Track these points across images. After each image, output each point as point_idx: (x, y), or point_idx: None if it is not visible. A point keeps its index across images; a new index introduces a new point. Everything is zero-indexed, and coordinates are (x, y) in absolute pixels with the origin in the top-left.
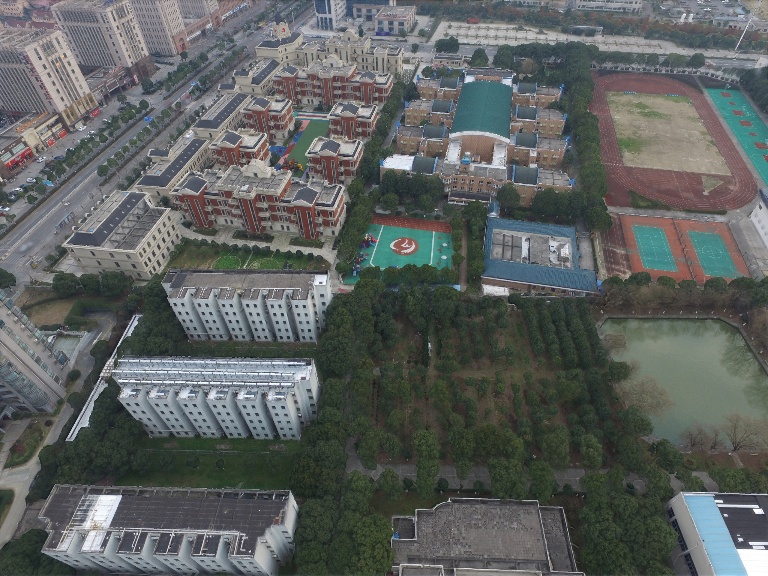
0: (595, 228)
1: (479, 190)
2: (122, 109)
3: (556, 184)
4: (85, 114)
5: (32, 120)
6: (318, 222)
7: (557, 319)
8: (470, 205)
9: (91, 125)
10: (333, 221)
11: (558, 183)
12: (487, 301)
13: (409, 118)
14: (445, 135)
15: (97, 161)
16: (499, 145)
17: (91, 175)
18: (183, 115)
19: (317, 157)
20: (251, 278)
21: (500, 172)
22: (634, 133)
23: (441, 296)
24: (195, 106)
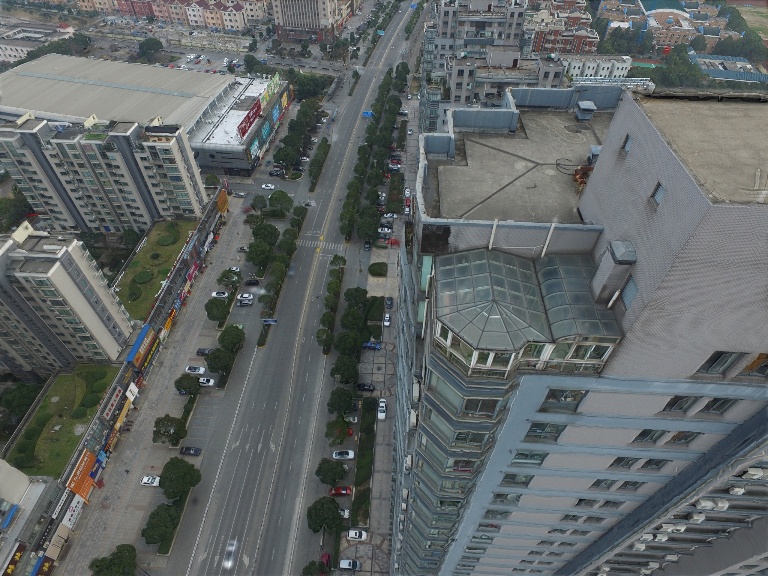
0: (762, 58)
1: (676, 42)
2: (378, 5)
3: (732, 36)
4: (360, 4)
5: (337, 2)
6: (585, 50)
7: (759, 90)
8: (679, 45)
9: (363, 13)
10: (593, 50)
11: (733, 35)
12: (714, 81)
13: (602, 10)
14: (641, 14)
15: (389, 29)
16: (681, 19)
17: (394, 35)
18: (425, 10)
19: (564, 20)
20: (585, 56)
21: (691, 30)
22: (761, 25)
23: (690, 75)
24: (429, 5)
